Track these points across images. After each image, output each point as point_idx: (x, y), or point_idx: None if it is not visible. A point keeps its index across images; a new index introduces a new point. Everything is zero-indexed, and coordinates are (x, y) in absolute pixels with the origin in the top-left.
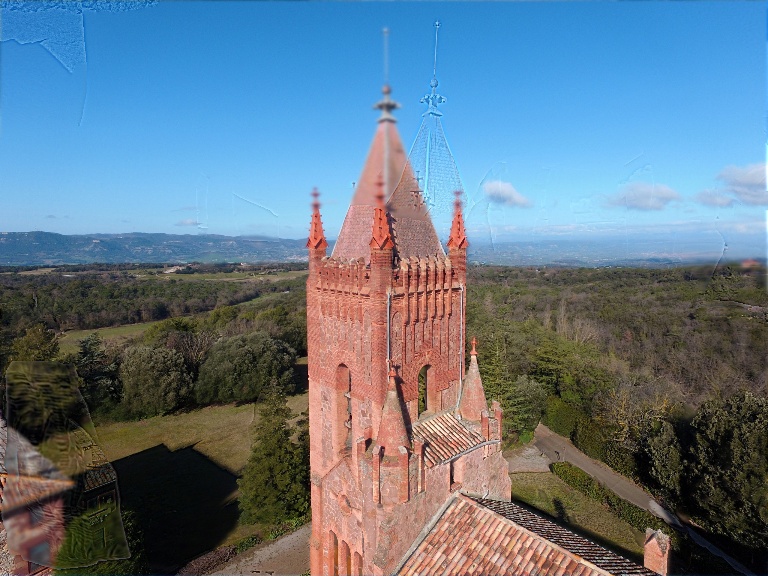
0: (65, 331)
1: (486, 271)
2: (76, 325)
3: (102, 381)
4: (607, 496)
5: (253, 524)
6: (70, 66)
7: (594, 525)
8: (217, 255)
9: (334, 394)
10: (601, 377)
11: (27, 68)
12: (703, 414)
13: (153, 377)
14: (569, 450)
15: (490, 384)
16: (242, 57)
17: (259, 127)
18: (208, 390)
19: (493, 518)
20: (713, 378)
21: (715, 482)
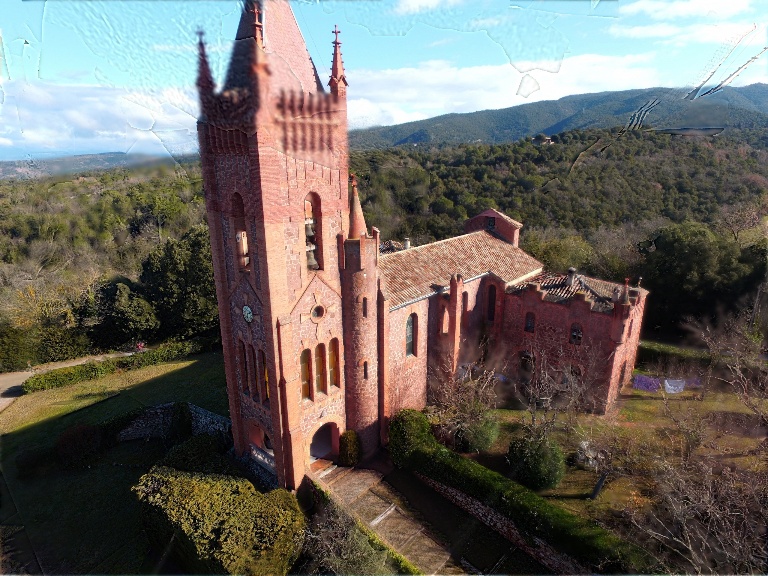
0: None
1: None
2: None
3: None
4: (119, 361)
5: None
6: (595, 5)
7: (145, 377)
8: None
9: (303, 224)
10: None
11: (606, 5)
12: (158, 260)
13: None
14: None
15: None
16: (549, 6)
17: None
18: None
19: None
20: None
21: (199, 294)
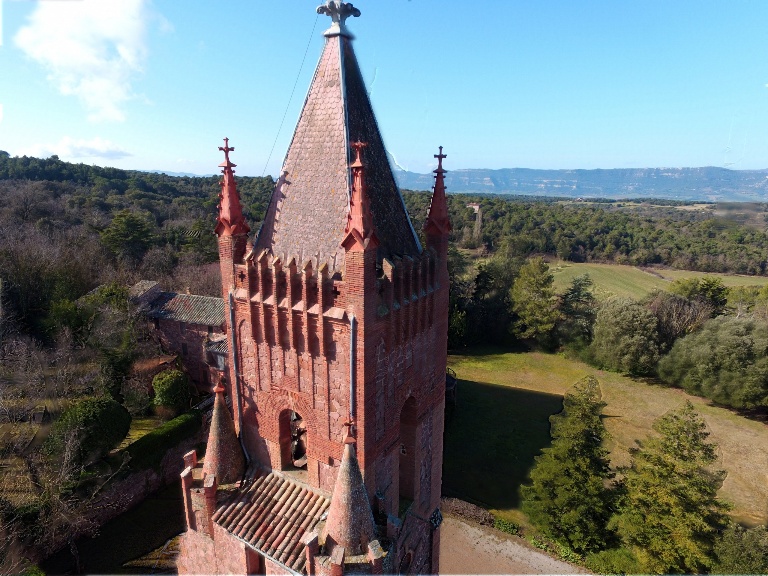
0: (562, 267)
1: None
2: (574, 263)
3: (579, 320)
4: None
5: (526, 515)
6: None
7: None
8: (746, 207)
9: None
10: None
11: None
12: None
13: (615, 332)
14: None
15: None
16: None
17: None
18: (674, 370)
19: None
20: None
21: None
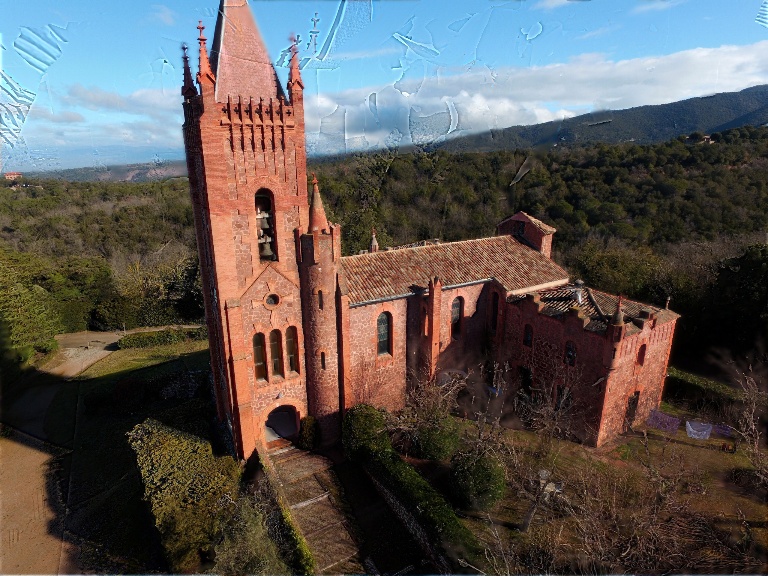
0: None
1: (26, 150)
2: None
3: None
4: (188, 332)
5: None
6: None
7: (203, 347)
8: None
9: (253, 217)
10: (93, 265)
11: None
12: None
13: None
14: (101, 336)
15: (5, 299)
16: None
17: (475, 23)
18: None
19: (347, 259)
20: (180, 239)
21: None
